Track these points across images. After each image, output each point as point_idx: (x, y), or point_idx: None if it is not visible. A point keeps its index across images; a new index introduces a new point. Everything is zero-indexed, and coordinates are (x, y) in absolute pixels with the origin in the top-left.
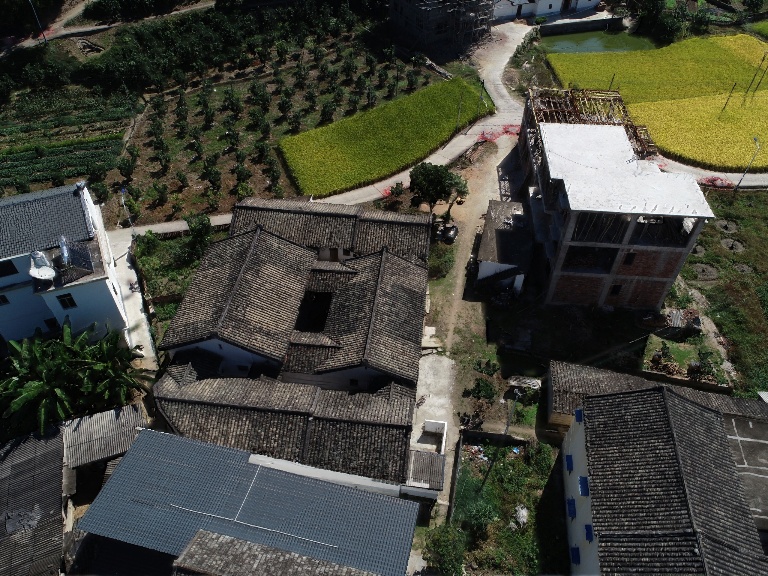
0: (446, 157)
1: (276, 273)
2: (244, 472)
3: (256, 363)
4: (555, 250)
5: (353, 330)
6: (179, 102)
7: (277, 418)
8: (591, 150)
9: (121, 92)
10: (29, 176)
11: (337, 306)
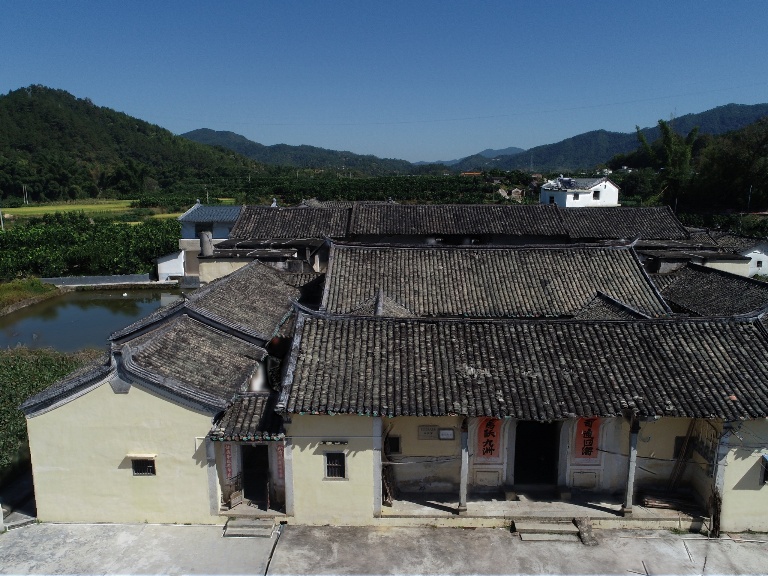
0: None
1: None
2: None
3: None
4: None
5: None
6: None
7: None
8: None
9: None
10: None
11: None
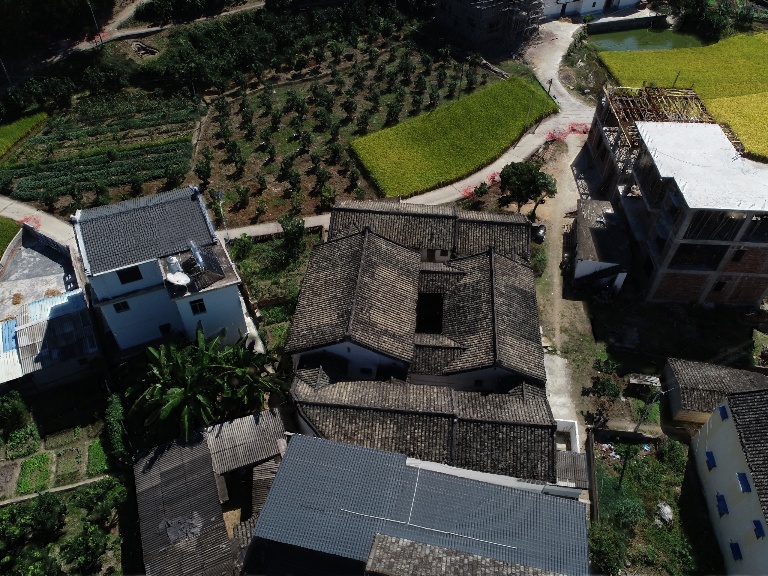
0: (519, 156)
1: (389, 275)
2: (405, 475)
3: (382, 365)
4: (659, 248)
5: (475, 331)
6: (242, 104)
7: (421, 420)
8: (693, 148)
9: (182, 94)
10: (105, 180)
11: (451, 307)
